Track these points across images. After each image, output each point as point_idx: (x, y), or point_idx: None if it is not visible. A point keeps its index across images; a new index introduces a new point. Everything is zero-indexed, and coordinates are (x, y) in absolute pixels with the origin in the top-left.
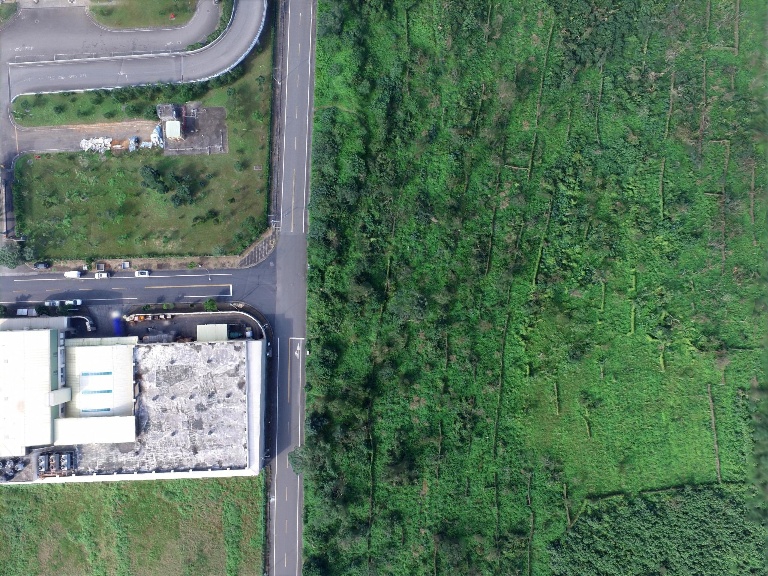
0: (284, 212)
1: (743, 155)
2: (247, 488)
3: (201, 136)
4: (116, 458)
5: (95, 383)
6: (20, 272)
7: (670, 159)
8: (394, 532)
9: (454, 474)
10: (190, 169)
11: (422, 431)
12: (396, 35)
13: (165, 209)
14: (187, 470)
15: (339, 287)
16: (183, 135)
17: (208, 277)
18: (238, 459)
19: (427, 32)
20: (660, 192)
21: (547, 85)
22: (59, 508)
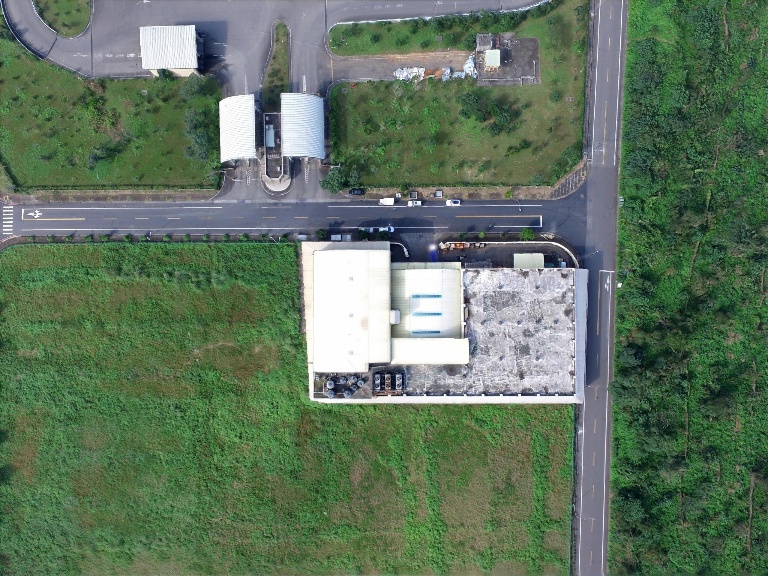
0: (595, 144)
1: None
2: (556, 419)
3: (514, 67)
4: (444, 380)
5: (426, 305)
6: (333, 199)
7: None
8: (709, 468)
9: (767, 412)
10: (502, 99)
11: (736, 368)
12: None
13: (478, 139)
14: (515, 395)
15: (656, 219)
16: None
17: (518, 208)
18: (564, 386)
19: None
20: None
21: None
22: (370, 431)
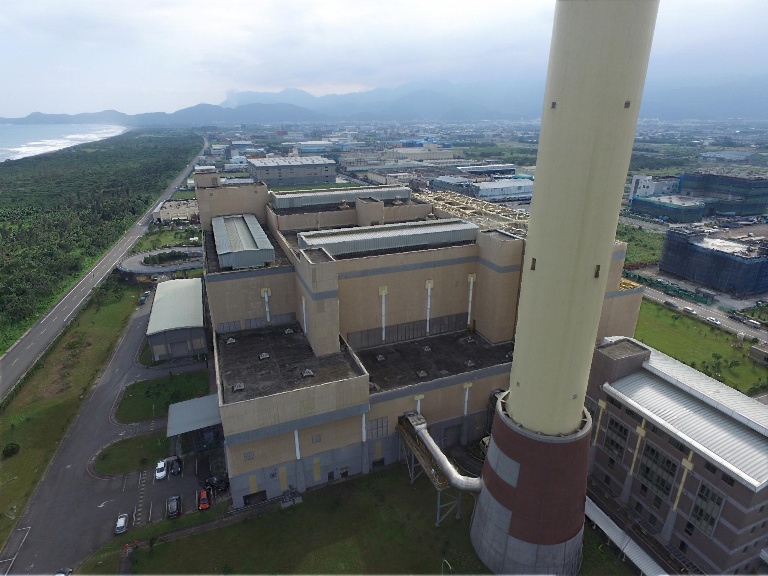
0: None
1: None
2: None
3: None
4: None
5: None
6: None
7: None
8: None
9: None
10: None
11: None
12: None
13: None
14: (191, 199)
15: None
16: None
17: None
18: None
19: None
20: None
21: None
22: None
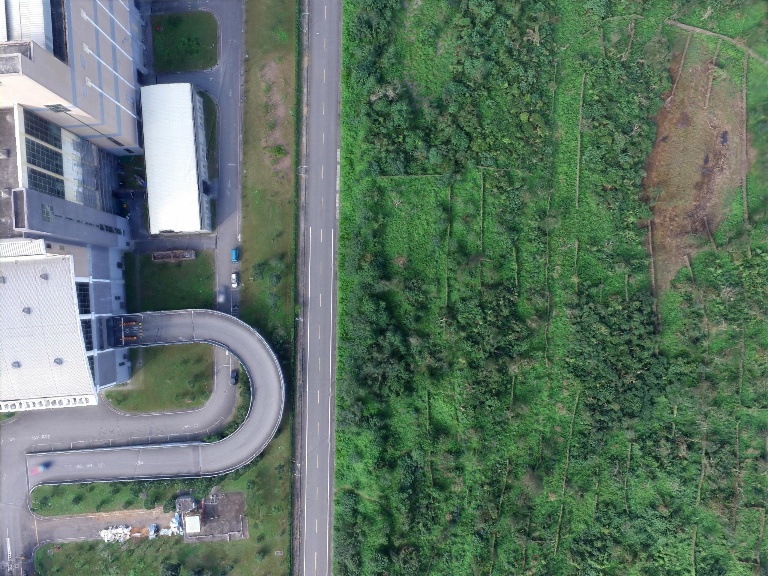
0: None
1: None
2: None
3: (221, 522)
4: None
5: None
6: None
7: (702, 526)
8: None
9: None
10: (211, 556)
11: None
12: (417, 409)
13: None
14: None
15: None
16: (203, 522)
17: None
18: None
19: (449, 411)
20: (692, 561)
21: (574, 457)
22: None
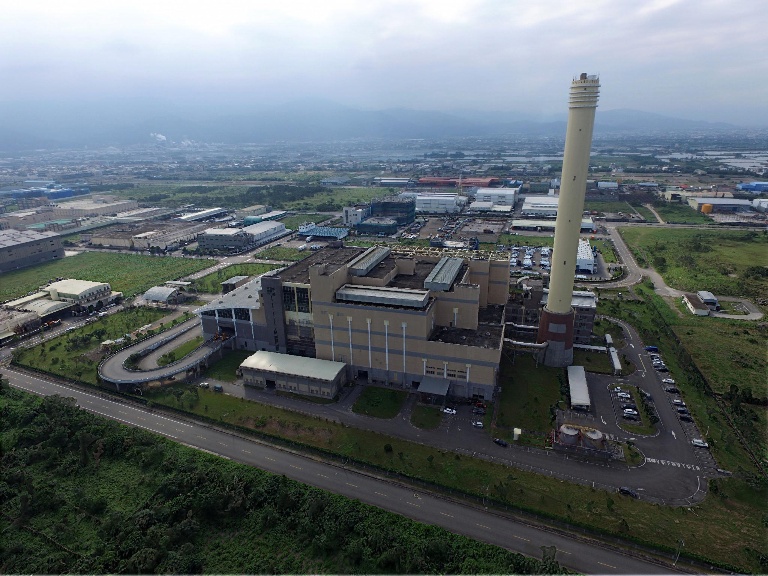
0: (7, 371)
1: None
2: None
3: None
4: None
5: None
6: None
7: None
8: None
9: None
10: None
11: None
12: None
13: None
14: None
15: None
16: None
17: None
18: None
19: None
20: None
21: None
22: None
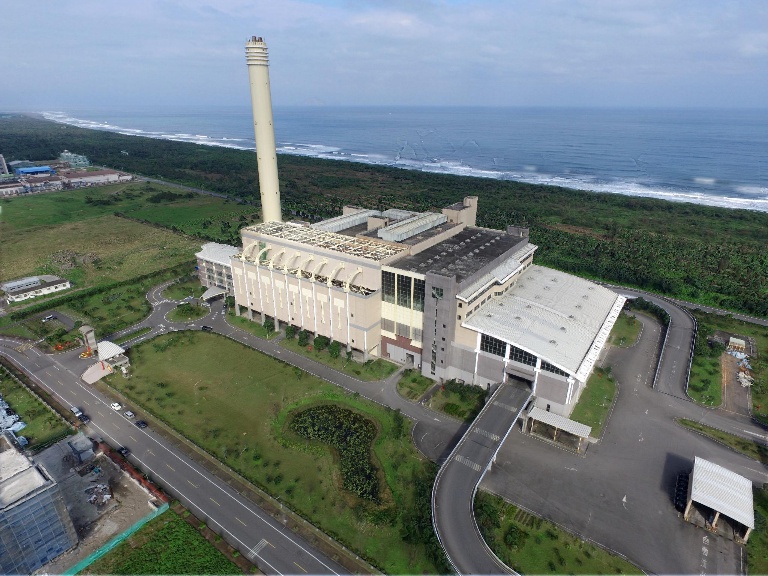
0: None
1: (760, 246)
2: None
3: None
4: None
5: None
6: None
7: None
8: None
9: None
10: None
11: None
12: None
13: None
14: None
15: None
16: None
17: None
18: None
19: None
20: None
21: None
22: None
